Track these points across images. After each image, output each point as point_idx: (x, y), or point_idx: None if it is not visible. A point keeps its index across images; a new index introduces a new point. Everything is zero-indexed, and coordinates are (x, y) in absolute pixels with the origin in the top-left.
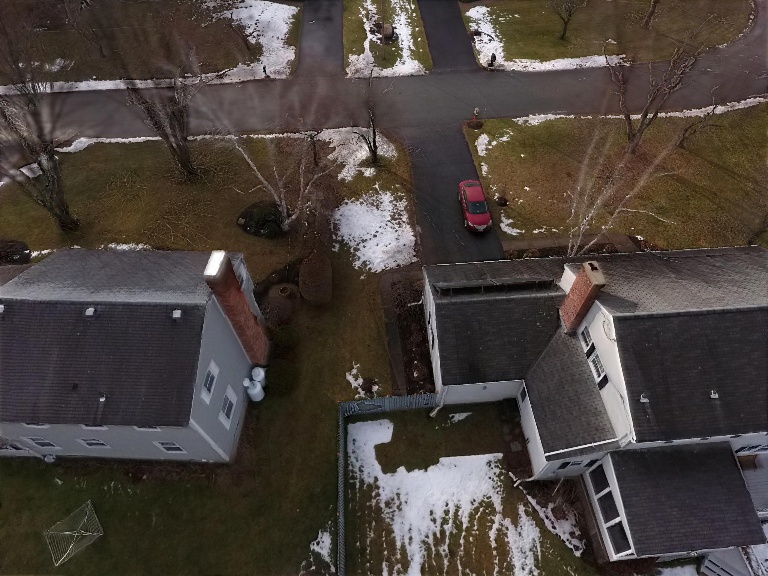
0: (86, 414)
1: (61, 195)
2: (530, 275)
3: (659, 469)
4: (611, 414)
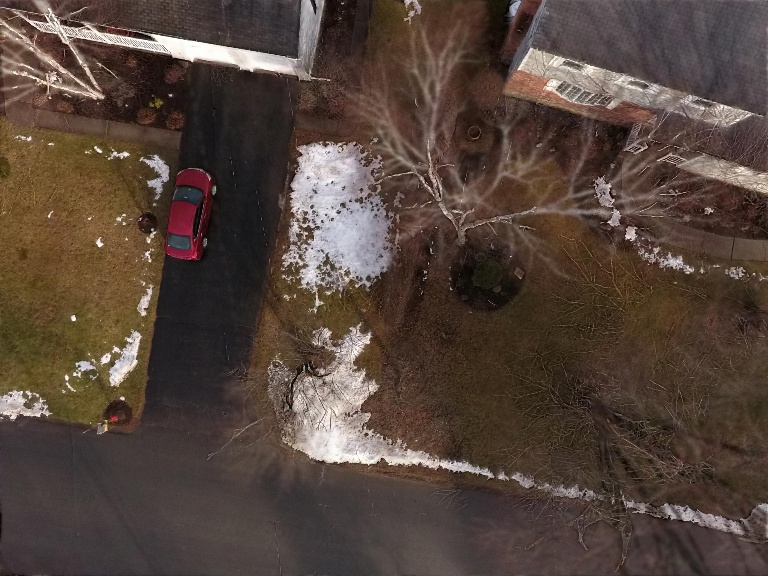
0: None
1: None
2: None
3: None
4: None
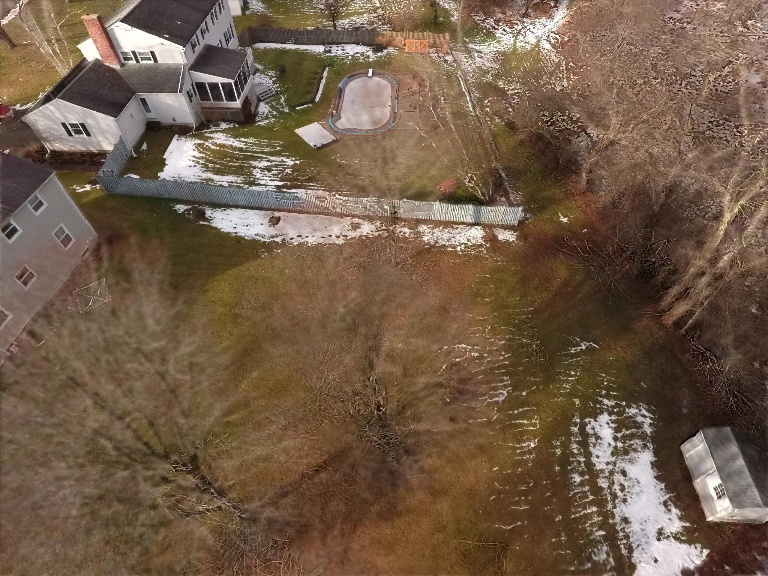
0: (2, 214)
1: None
2: None
3: (204, 62)
4: (171, 61)
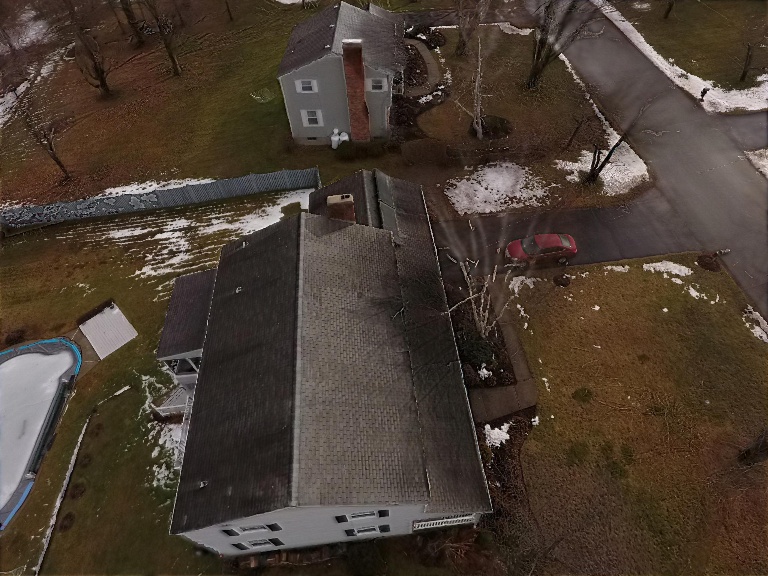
0: None
1: (470, 32)
2: (405, 238)
3: None
4: None
